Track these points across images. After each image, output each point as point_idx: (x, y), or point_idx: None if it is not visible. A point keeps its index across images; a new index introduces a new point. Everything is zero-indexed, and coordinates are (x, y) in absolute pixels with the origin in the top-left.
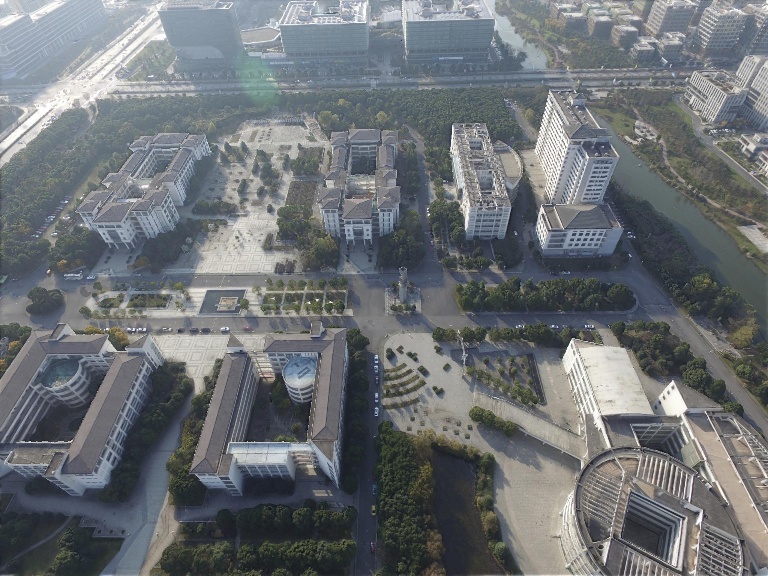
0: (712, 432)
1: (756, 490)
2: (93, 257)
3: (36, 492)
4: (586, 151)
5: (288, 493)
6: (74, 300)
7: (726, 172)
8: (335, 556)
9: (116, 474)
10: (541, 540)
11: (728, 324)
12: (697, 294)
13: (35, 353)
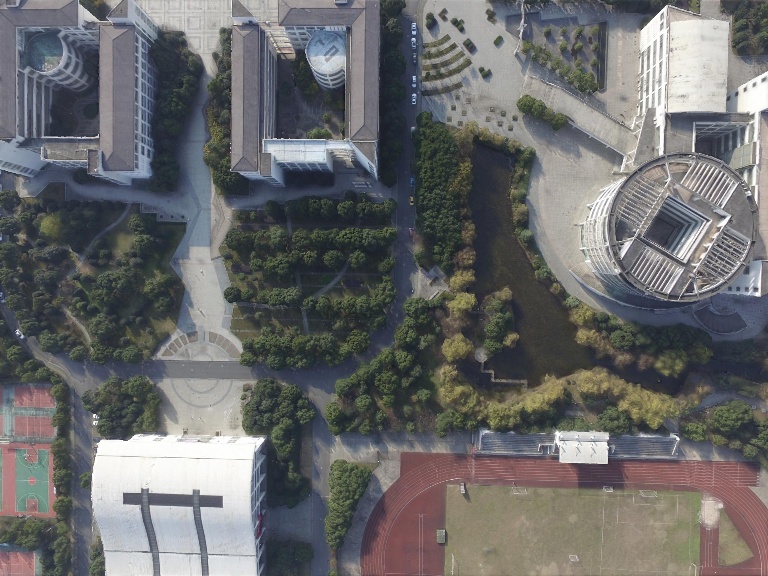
0: None
1: None
2: None
3: (85, 182)
4: None
5: (329, 185)
6: None
7: None
8: (379, 241)
9: (156, 167)
10: (564, 227)
11: None
12: None
13: (0, 26)
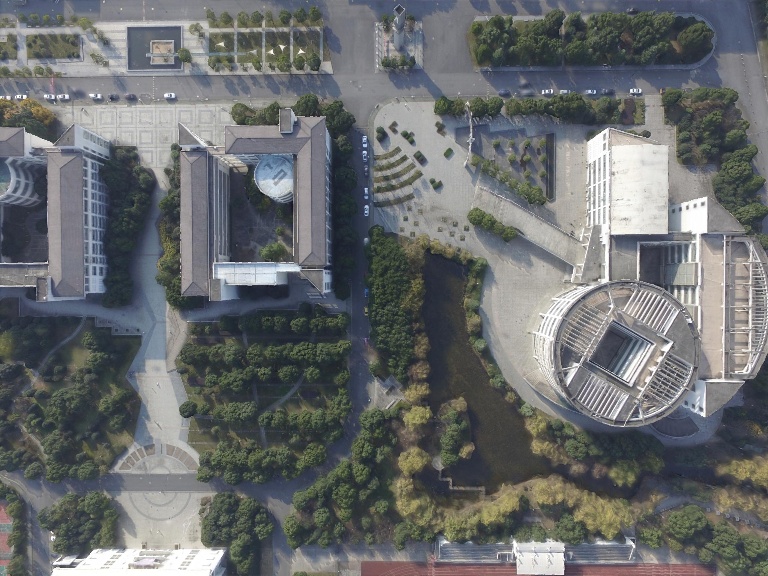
0: (720, 255)
1: (733, 314)
2: None
3: None
4: None
5: (283, 296)
6: None
7: None
8: (333, 357)
9: (109, 286)
10: (517, 335)
11: None
12: None
13: None
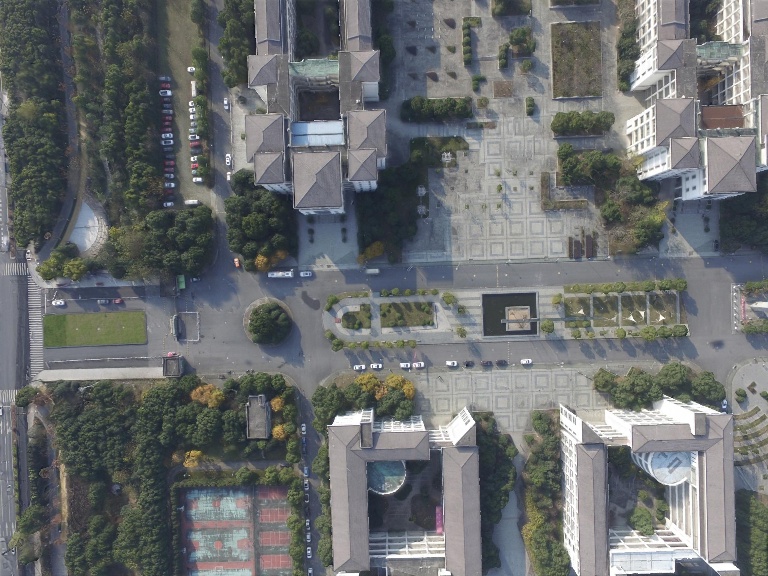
0: None
1: None
2: (292, 238)
3: None
4: None
5: None
6: (303, 316)
7: None
8: None
9: (484, 561)
10: None
11: None
12: None
13: (354, 465)
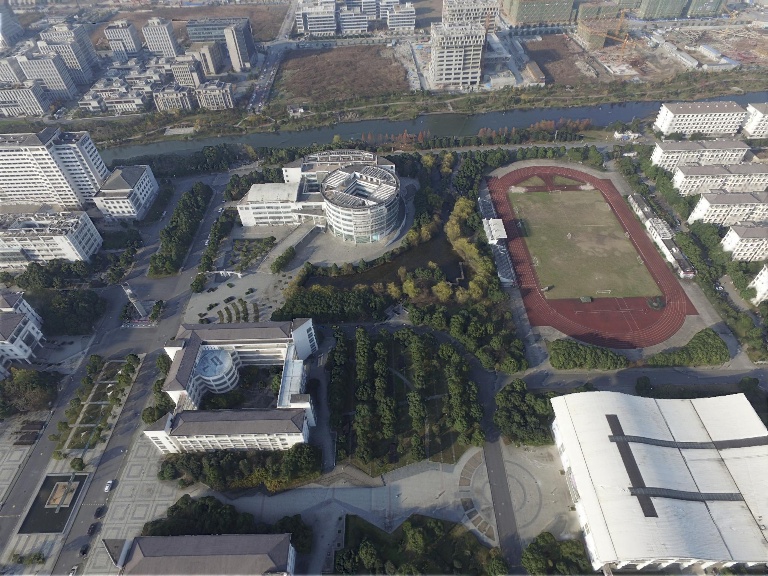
0: (314, 167)
1: None
2: None
3: None
4: (64, 144)
5: None
6: None
7: (109, 123)
8: None
9: None
10: (358, 251)
11: (240, 158)
12: (217, 158)
13: None
